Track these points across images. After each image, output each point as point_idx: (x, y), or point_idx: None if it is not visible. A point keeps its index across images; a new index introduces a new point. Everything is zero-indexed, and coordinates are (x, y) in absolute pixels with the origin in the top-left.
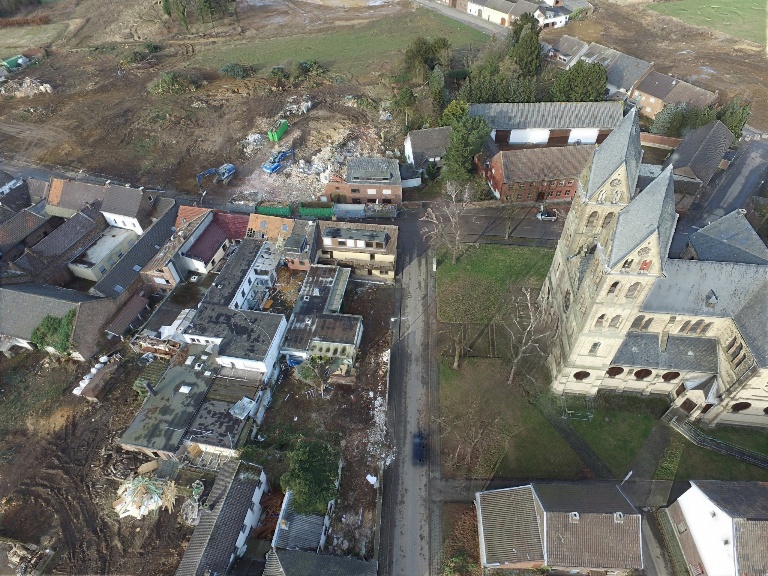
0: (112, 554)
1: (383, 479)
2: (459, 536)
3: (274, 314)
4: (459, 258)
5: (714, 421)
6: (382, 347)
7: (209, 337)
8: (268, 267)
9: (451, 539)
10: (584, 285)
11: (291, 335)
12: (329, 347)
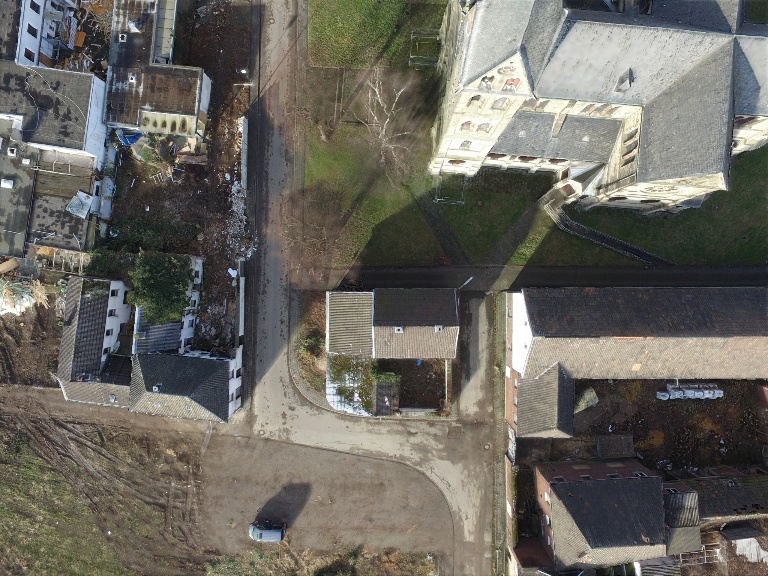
0: (8, 344)
1: (245, 271)
2: (315, 320)
3: (79, 74)
4: None
5: (588, 207)
6: (237, 110)
7: (5, 114)
8: None
9: (307, 323)
10: (454, 71)
11: (114, 102)
12: (165, 120)
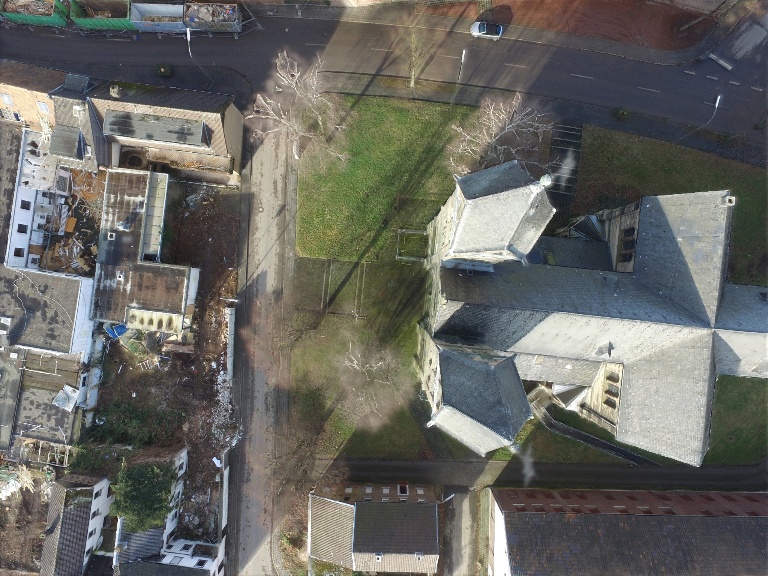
0: None
1: (230, 459)
2: (298, 511)
3: (67, 278)
4: (334, 133)
5: None
6: None
7: None
8: (42, 184)
9: (290, 514)
10: None
11: (101, 299)
12: (151, 318)
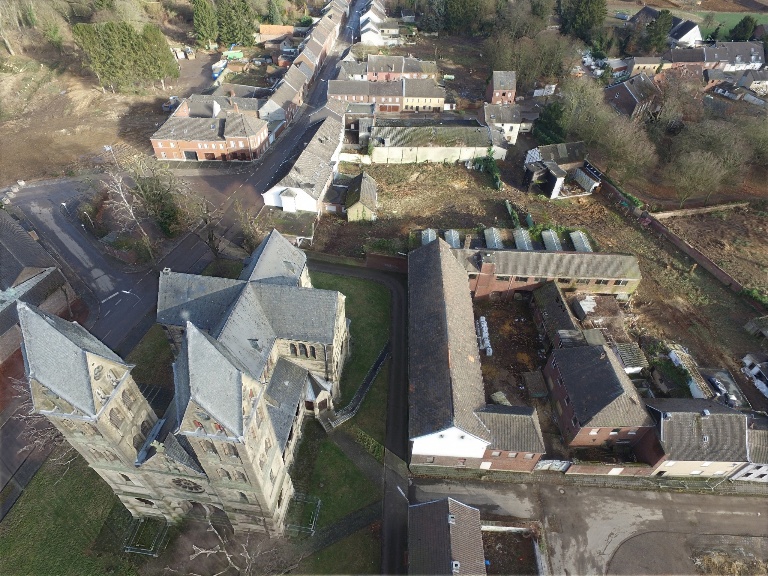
0: None
1: None
2: None
3: None
4: None
5: (339, 392)
6: None
7: None
8: None
9: None
10: (210, 465)
11: None
12: None
